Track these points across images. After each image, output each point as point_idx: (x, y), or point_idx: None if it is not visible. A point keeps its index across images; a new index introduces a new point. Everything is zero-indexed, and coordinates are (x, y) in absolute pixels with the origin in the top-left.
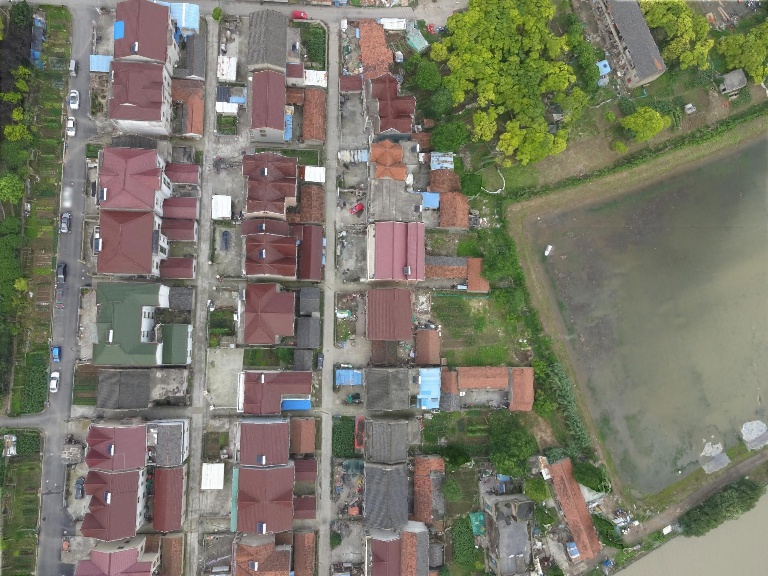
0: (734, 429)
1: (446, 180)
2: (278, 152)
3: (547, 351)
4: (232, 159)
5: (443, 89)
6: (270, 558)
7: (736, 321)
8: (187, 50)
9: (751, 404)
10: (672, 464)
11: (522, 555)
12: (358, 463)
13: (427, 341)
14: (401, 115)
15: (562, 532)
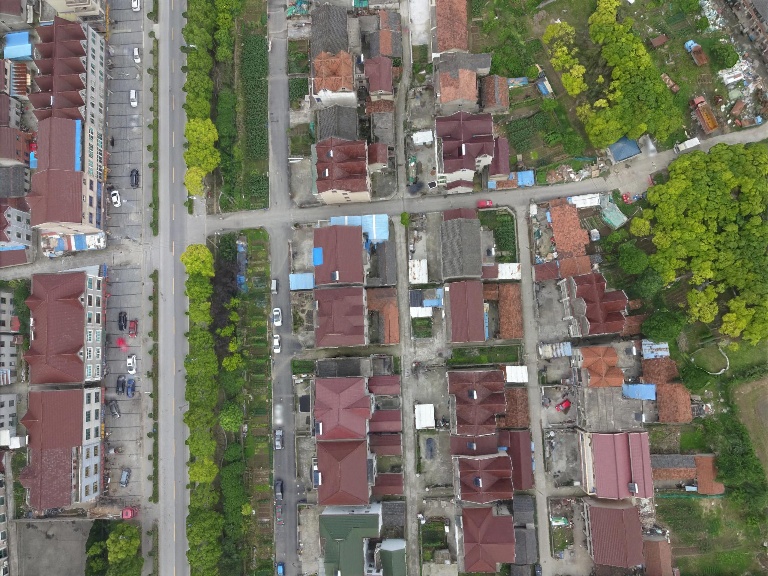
0: None
1: (662, 370)
2: (475, 350)
3: None
4: (429, 362)
5: (651, 272)
6: None
7: None
8: (378, 258)
9: None
10: None
11: None
12: None
13: (657, 554)
14: (610, 313)
15: None
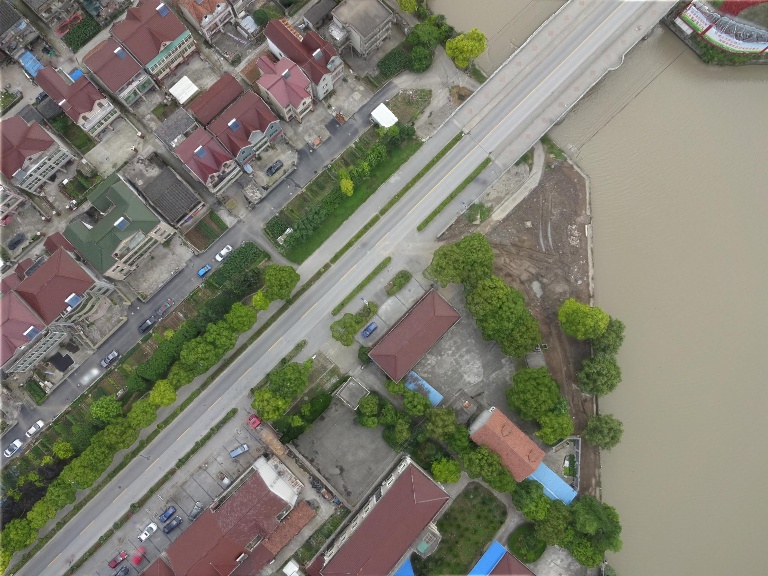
0: None
1: None
2: None
3: None
4: None
5: None
6: None
7: None
8: None
9: None
10: None
11: None
12: (87, 5)
13: None
14: None
15: None
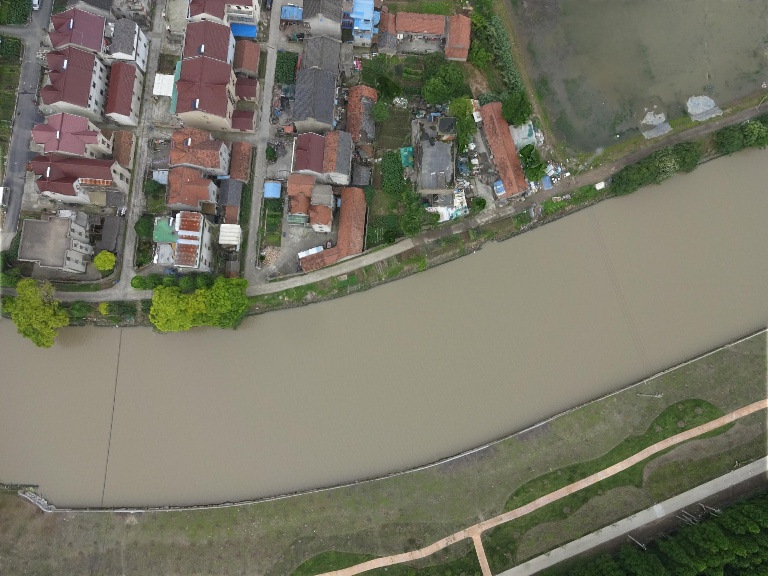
0: (679, 102)
1: None
2: None
3: (488, 10)
4: None
5: None
6: (204, 143)
7: (688, 1)
8: None
9: (699, 80)
10: (610, 128)
11: (443, 172)
12: None
13: None
14: None
15: (491, 176)
